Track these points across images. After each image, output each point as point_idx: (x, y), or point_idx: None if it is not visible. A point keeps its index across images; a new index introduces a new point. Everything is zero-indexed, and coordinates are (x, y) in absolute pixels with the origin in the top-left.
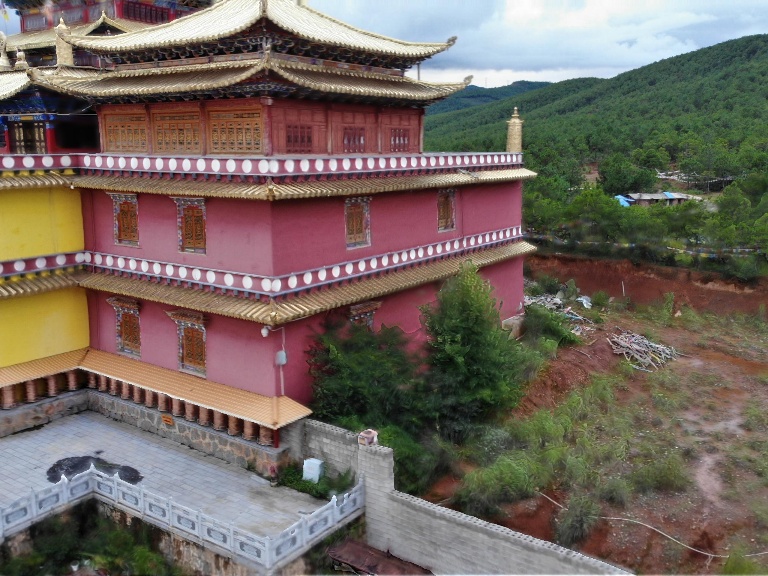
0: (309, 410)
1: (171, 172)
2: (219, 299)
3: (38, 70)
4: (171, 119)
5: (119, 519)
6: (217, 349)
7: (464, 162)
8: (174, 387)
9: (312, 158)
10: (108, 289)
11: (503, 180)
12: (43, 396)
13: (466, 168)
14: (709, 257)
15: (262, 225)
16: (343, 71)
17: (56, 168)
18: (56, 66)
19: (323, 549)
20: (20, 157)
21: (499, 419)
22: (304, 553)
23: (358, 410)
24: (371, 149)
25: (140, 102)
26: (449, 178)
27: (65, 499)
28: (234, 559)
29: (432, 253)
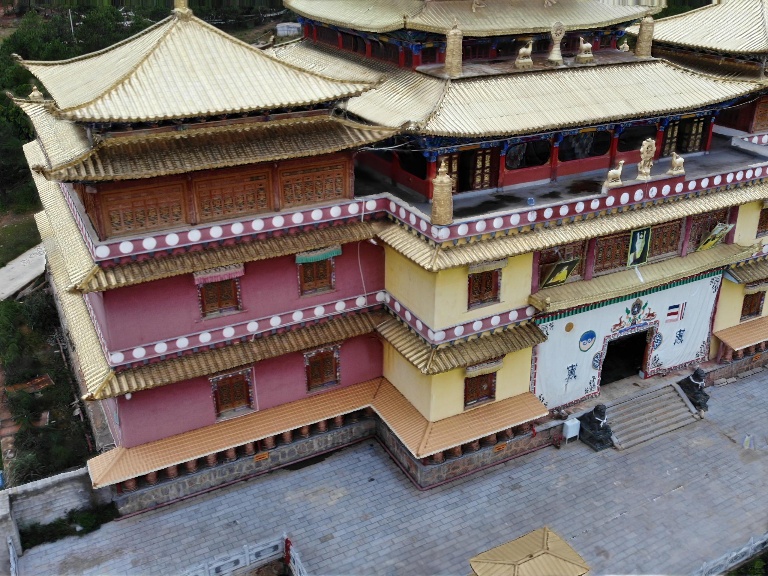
0: None
1: None
2: None
3: None
4: None
5: None
6: None
7: None
8: None
9: None
10: None
11: None
12: None
13: None
14: None
15: None
16: None
17: None
18: (653, 60)
19: None
20: None
21: None
22: None
23: None
24: None
25: None
26: None
27: None
28: None
29: None
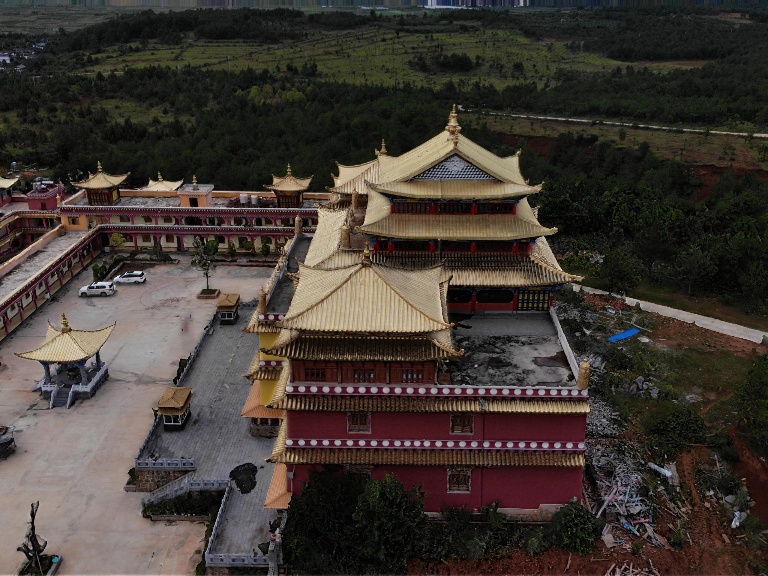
0: None
1: None
2: None
3: (290, 275)
4: None
5: None
6: None
7: (490, 393)
8: None
9: (320, 386)
10: None
11: (527, 413)
12: (277, 424)
13: (492, 397)
14: None
15: None
16: (364, 336)
17: None
18: None
19: (239, 570)
20: (277, 315)
21: (384, 568)
22: (227, 567)
23: None
24: (381, 381)
25: None
26: (450, 407)
27: (216, 486)
28: None
29: (441, 445)
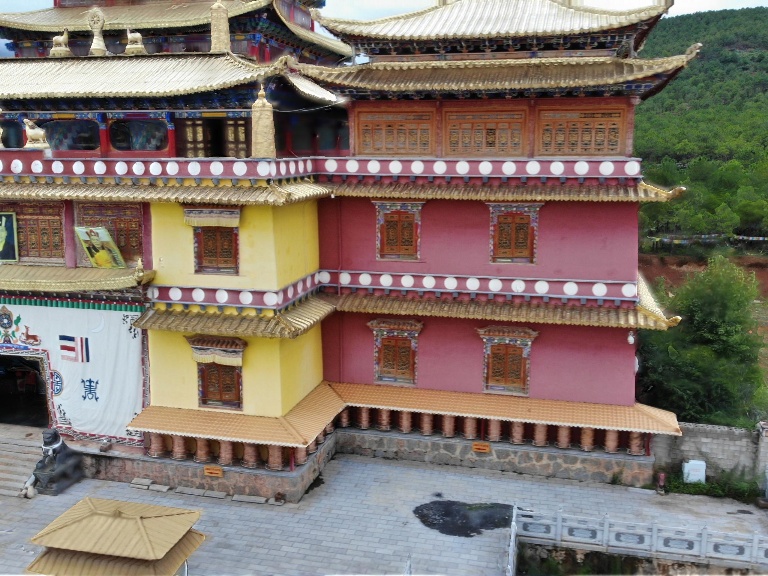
0: (672, 413)
1: (485, 176)
2: (565, 310)
3: None
4: (475, 118)
5: (563, 558)
6: (548, 363)
7: None
8: (504, 410)
9: None
10: (391, 311)
11: None
12: None
13: None
14: (681, 243)
15: (627, 229)
16: None
17: (305, 174)
18: (218, 53)
19: None
20: (288, 162)
21: None
22: None
23: (715, 406)
24: None
25: (427, 99)
26: None
27: (514, 548)
28: (757, 569)
29: None
